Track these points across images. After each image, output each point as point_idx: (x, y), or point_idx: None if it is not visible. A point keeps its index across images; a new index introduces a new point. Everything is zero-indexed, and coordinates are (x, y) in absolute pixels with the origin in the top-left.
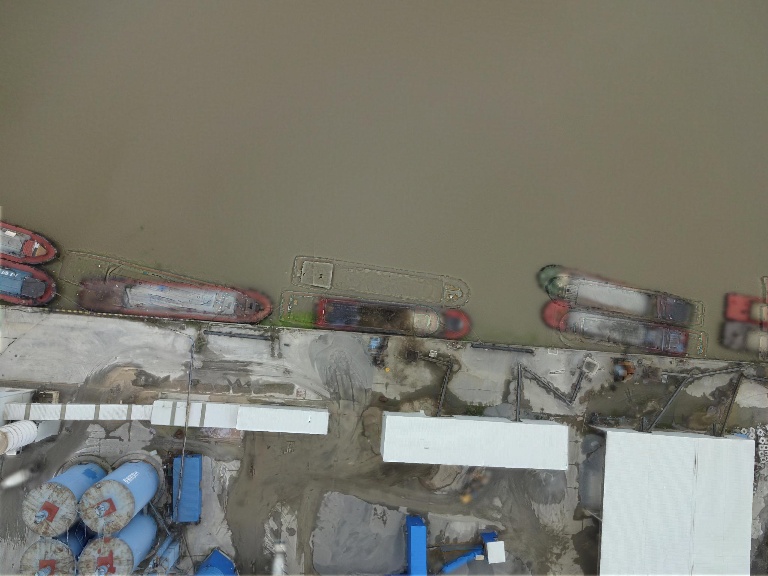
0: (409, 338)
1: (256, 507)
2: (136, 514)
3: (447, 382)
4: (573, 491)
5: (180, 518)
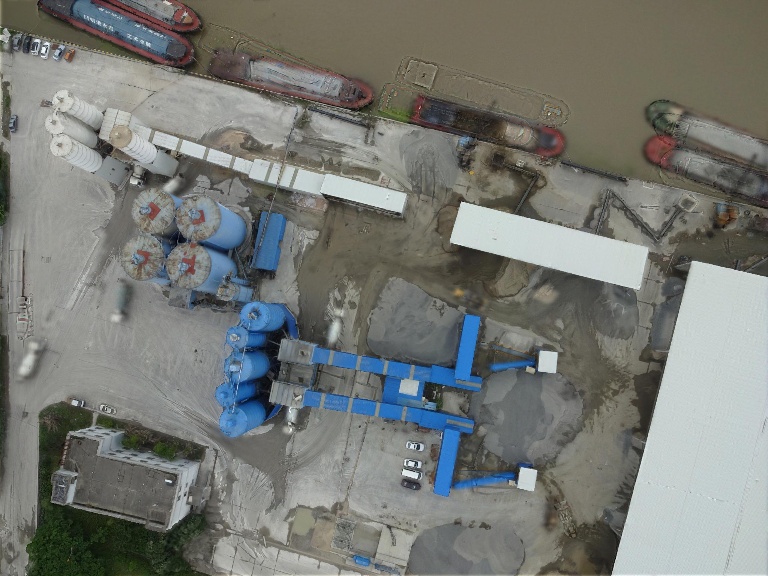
0: (499, 147)
1: (325, 276)
2: (221, 247)
3: (529, 191)
4: (644, 331)
5: (258, 264)
